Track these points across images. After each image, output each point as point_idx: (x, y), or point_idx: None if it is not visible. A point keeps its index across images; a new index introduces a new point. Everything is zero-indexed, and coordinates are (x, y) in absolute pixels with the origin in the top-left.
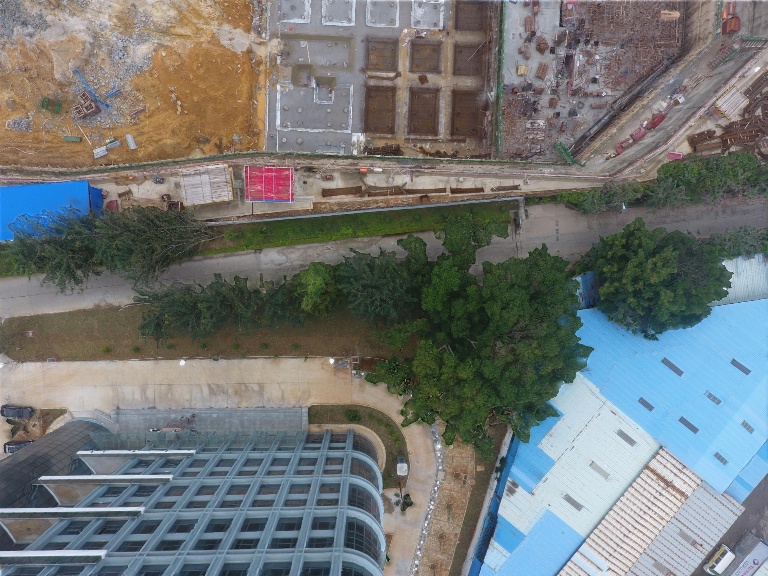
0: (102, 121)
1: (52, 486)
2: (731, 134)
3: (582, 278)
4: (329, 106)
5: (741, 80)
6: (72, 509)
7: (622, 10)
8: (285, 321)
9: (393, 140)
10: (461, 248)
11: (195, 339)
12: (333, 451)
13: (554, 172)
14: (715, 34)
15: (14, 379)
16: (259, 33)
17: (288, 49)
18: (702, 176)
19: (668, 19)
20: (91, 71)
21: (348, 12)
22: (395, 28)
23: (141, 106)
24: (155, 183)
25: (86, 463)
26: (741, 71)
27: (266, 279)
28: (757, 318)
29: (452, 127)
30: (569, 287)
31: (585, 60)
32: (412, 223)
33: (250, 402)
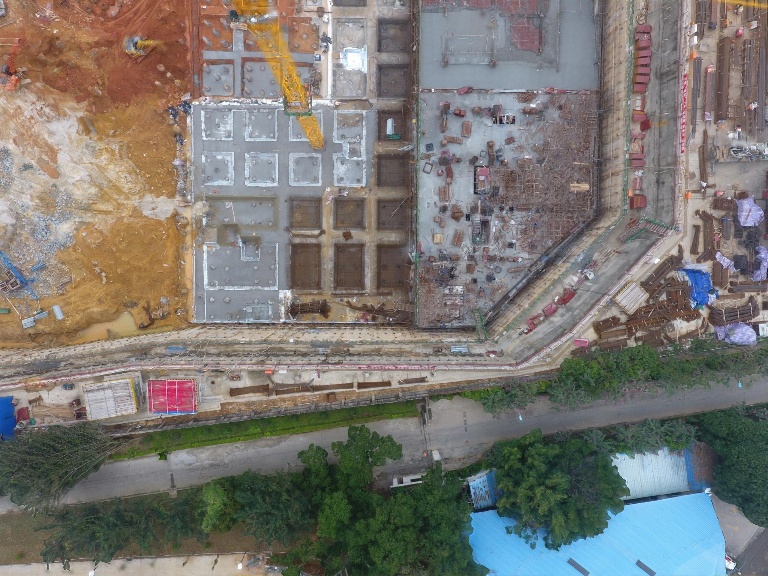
0: (29, 293)
1: None
2: (635, 321)
3: (487, 477)
4: (256, 264)
5: (644, 266)
6: None
7: (532, 183)
8: (188, 537)
9: (320, 295)
10: (356, 469)
11: (98, 561)
12: None
13: (461, 362)
14: (623, 209)
15: None
16: (184, 195)
17: (213, 210)
18: (601, 377)
19: (578, 190)
20: (16, 247)
21: (271, 172)
22: (318, 187)
23: (67, 278)
24: (65, 389)
25: None
26: (643, 258)
27: (177, 479)
28: (661, 518)
29: (378, 280)
30: (460, 515)
31: (501, 225)
32: (320, 420)
33: None
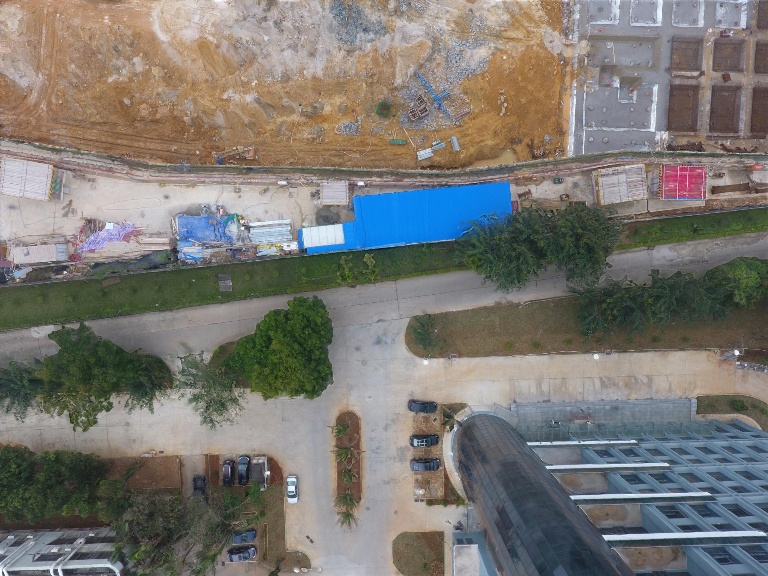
0: (428, 124)
1: (558, 475)
2: None
3: None
4: (632, 105)
5: None
6: (639, 495)
7: None
8: (710, 315)
9: (695, 138)
10: None
11: (630, 333)
12: (765, 439)
13: None
14: None
15: (418, 375)
16: (566, 35)
17: (594, 50)
18: None
19: None
20: (423, 75)
21: (653, 13)
22: (700, 28)
23: (467, 108)
24: (554, 183)
25: (537, 454)
26: None
27: None
28: None
29: (751, 124)
30: None
31: None
32: None
33: (639, 394)
